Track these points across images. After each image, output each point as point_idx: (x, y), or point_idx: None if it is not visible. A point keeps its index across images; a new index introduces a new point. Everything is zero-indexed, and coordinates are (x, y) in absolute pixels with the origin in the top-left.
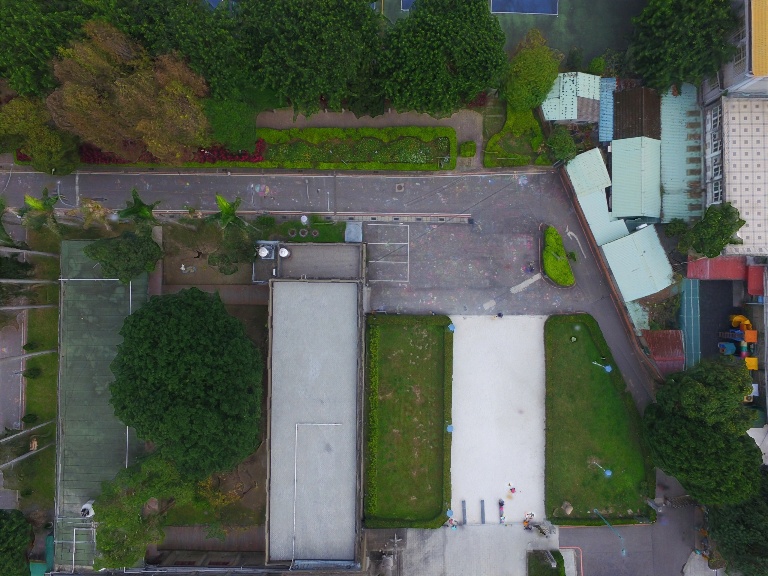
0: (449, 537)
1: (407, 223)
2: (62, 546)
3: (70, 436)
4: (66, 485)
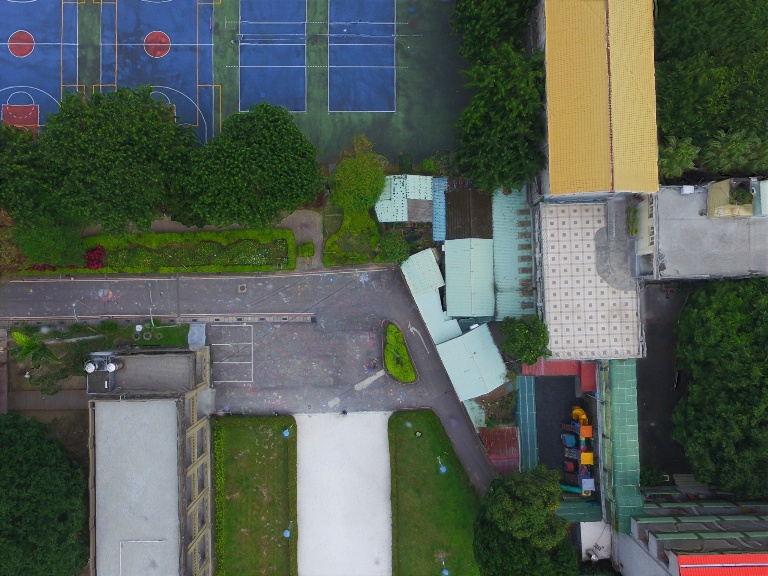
0: None
1: (250, 323)
2: None
3: None
4: None
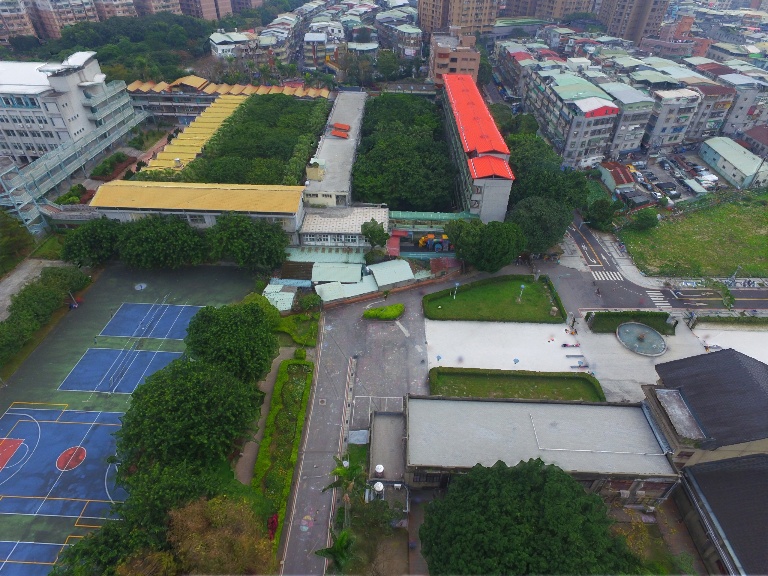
0: (603, 377)
1: (353, 398)
2: None
3: None
4: None
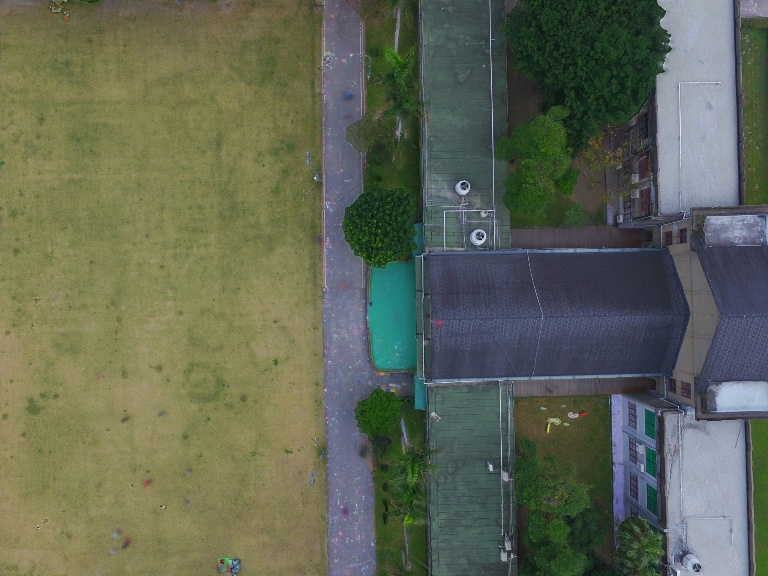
0: None
1: None
2: (431, 229)
3: (435, 123)
4: (433, 170)
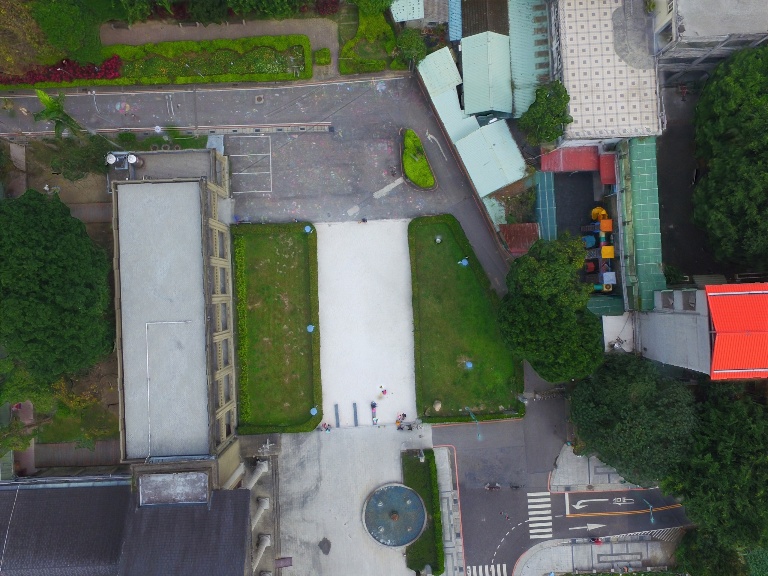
0: (323, 441)
1: (268, 134)
2: None
3: None
4: None
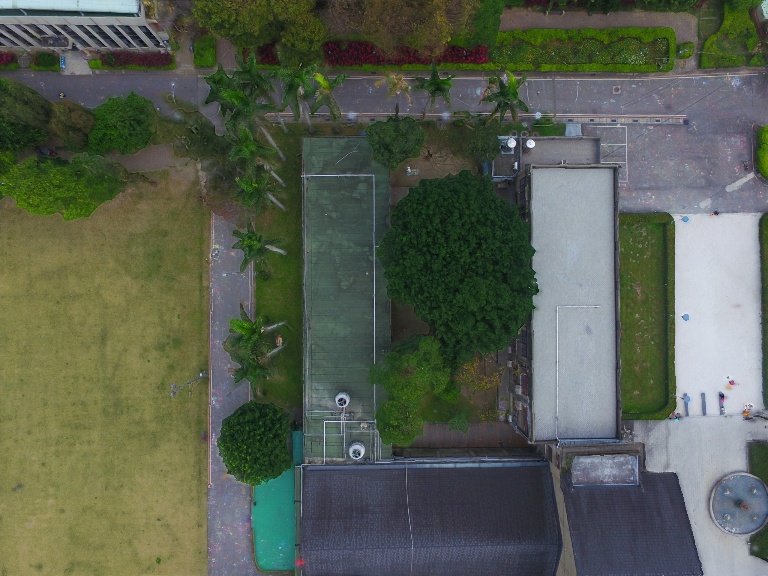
0: (672, 429)
1: (624, 124)
2: (311, 439)
3: (317, 331)
4: (314, 379)
